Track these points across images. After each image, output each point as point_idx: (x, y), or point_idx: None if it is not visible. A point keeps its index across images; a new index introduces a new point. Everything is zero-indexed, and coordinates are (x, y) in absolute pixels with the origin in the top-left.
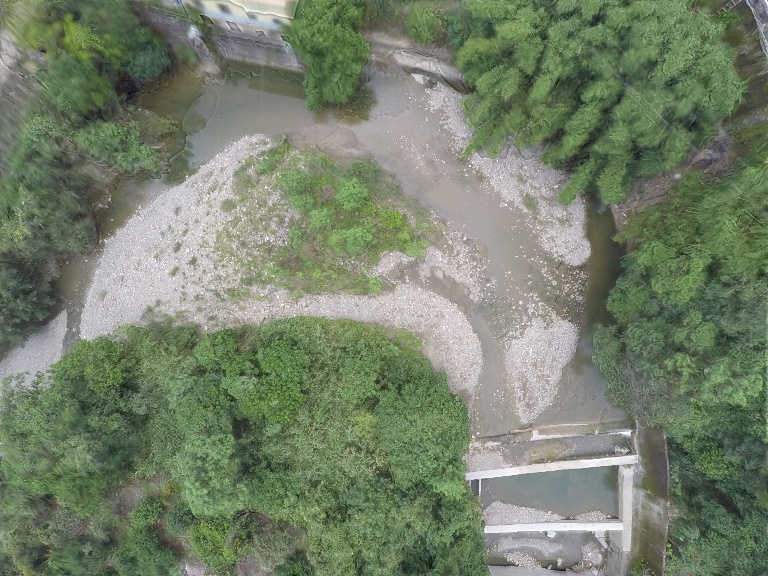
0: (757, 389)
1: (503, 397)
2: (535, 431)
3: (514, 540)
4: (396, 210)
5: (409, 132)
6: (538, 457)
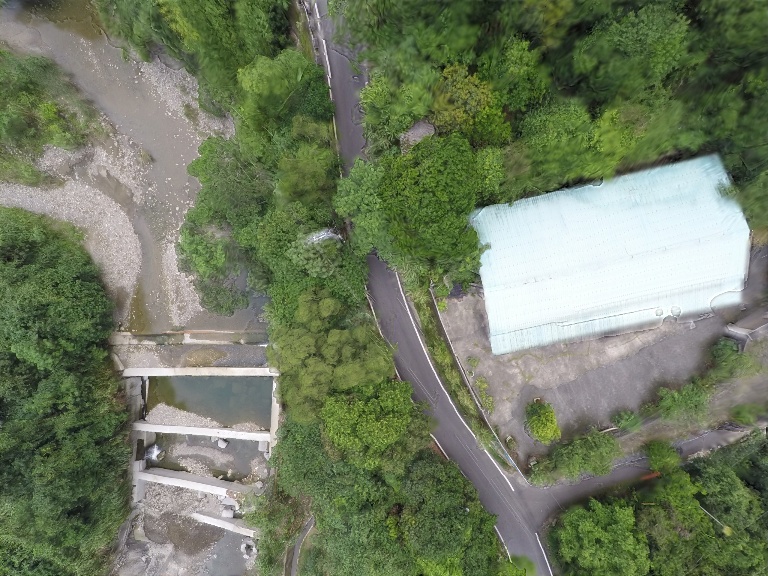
0: (219, 259)
1: (158, 298)
2: (186, 334)
3: (188, 447)
4: (67, 108)
5: (89, 37)
6: (193, 361)
